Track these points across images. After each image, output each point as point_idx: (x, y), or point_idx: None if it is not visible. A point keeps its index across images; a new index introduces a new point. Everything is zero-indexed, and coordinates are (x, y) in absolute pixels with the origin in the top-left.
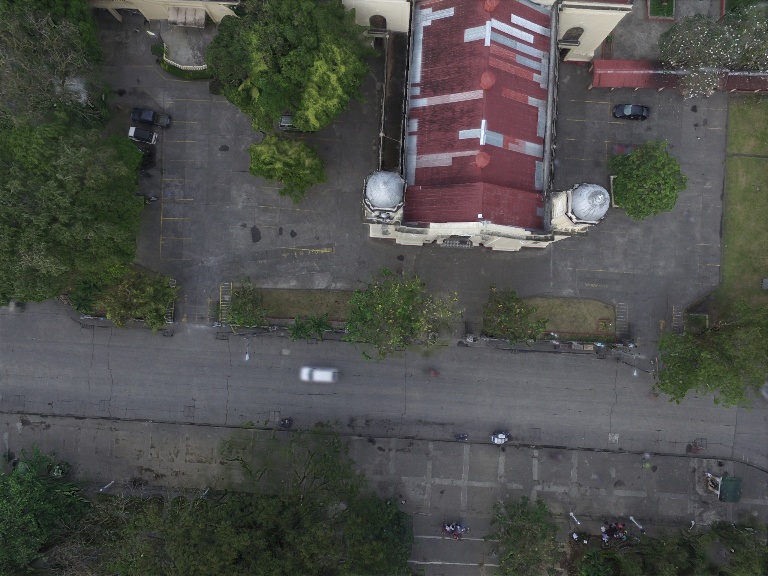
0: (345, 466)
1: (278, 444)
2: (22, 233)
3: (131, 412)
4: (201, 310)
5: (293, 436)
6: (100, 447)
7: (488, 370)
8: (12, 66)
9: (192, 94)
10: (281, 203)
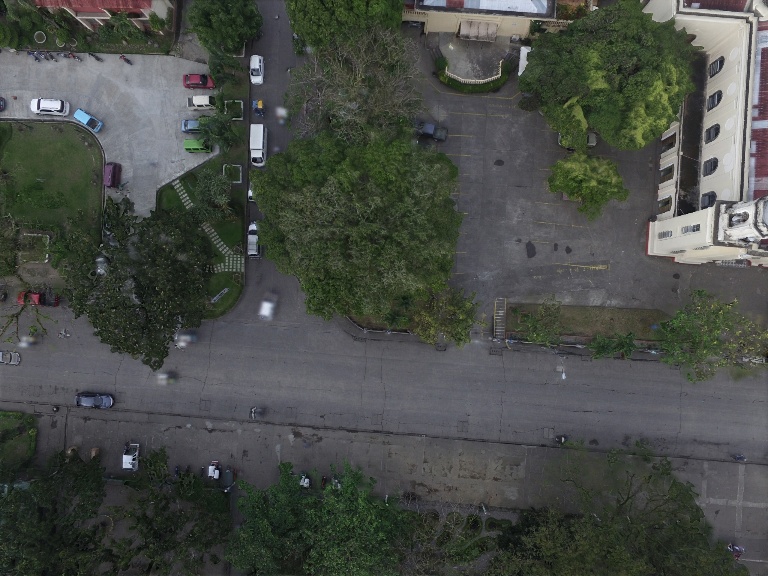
0: (687, 489)
1: (552, 461)
2: (382, 250)
3: (404, 426)
4: (475, 325)
5: (608, 456)
6: (373, 461)
7: (763, 390)
8: (369, 81)
9: (467, 108)
10: (556, 219)
